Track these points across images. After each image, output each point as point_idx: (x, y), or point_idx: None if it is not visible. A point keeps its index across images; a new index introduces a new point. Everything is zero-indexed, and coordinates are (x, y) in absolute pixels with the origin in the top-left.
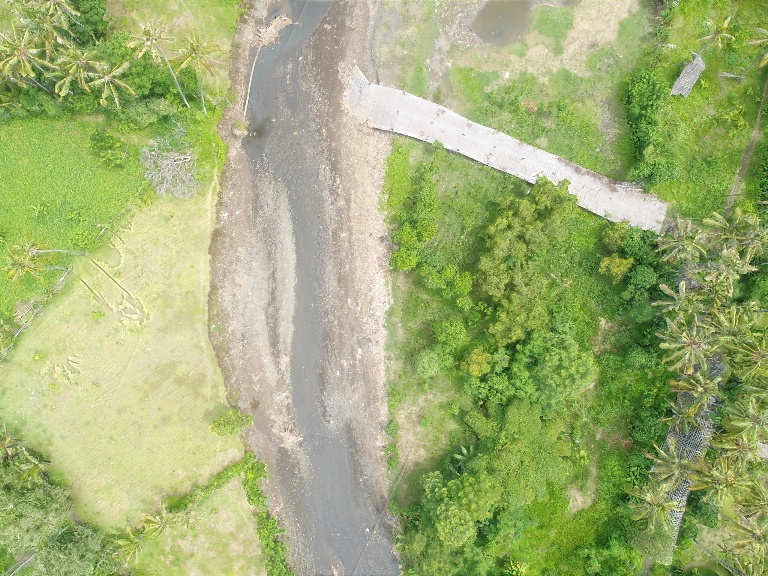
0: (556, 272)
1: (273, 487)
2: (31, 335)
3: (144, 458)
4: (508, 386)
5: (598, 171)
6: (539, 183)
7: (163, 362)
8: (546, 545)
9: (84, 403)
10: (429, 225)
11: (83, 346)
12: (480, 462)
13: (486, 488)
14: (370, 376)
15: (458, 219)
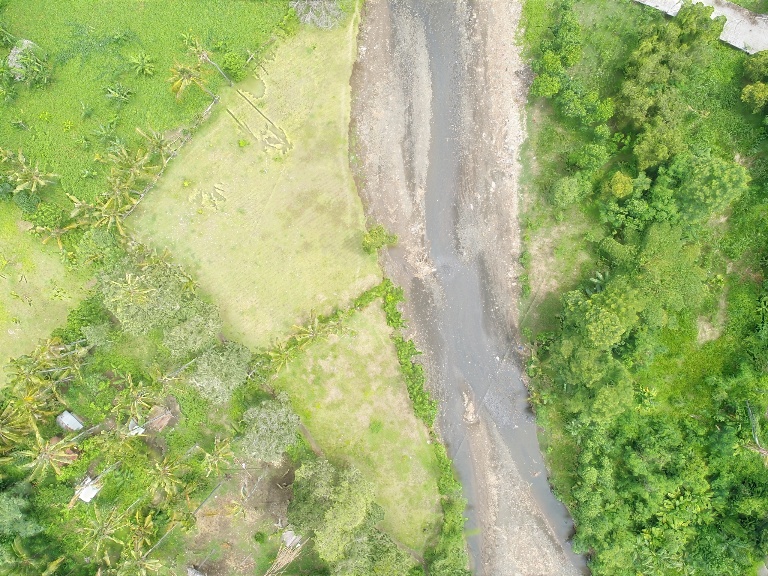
0: (693, 105)
1: (407, 315)
2: (179, 163)
3: (287, 282)
4: (648, 209)
5: (739, 3)
6: (685, 6)
7: (305, 190)
8: (674, 374)
9: (230, 229)
10: (574, 48)
11: (229, 174)
12: (620, 281)
13: (633, 297)
14: (503, 209)
15: (595, 53)
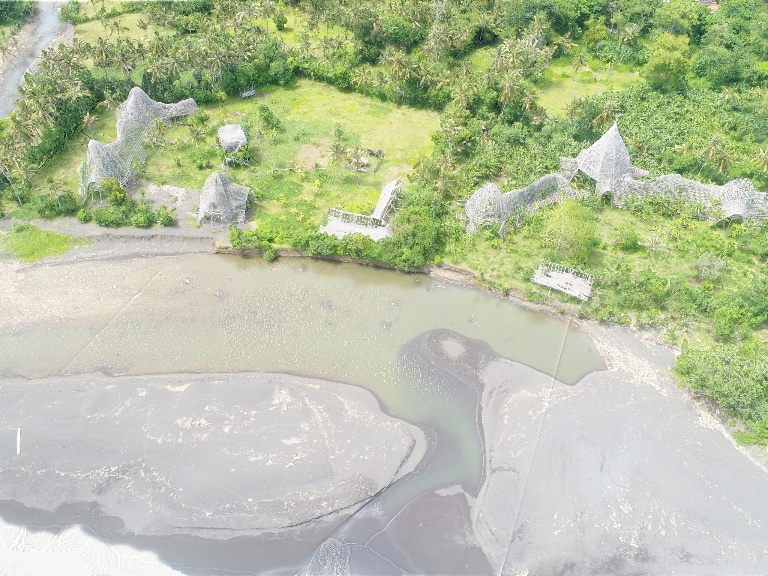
0: None
1: None
2: None
3: None
4: None
5: None
6: None
7: None
8: None
9: None
10: None
11: None
12: None
13: None
14: None
15: None
